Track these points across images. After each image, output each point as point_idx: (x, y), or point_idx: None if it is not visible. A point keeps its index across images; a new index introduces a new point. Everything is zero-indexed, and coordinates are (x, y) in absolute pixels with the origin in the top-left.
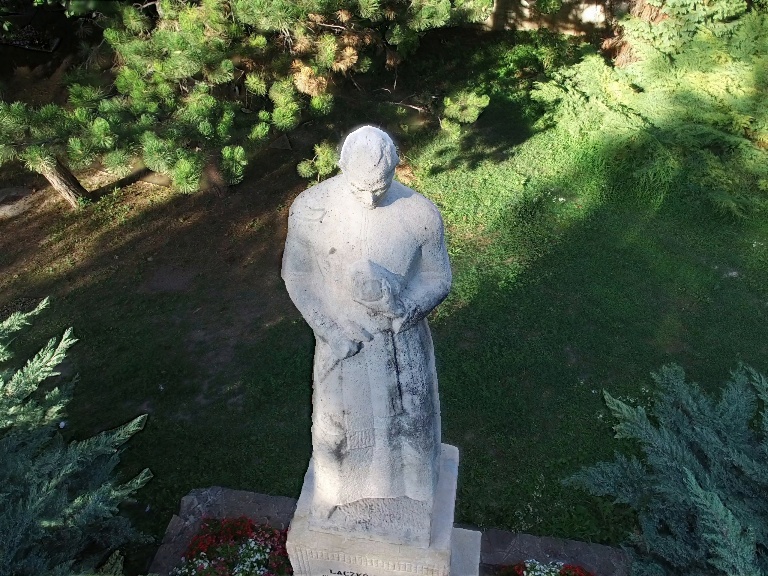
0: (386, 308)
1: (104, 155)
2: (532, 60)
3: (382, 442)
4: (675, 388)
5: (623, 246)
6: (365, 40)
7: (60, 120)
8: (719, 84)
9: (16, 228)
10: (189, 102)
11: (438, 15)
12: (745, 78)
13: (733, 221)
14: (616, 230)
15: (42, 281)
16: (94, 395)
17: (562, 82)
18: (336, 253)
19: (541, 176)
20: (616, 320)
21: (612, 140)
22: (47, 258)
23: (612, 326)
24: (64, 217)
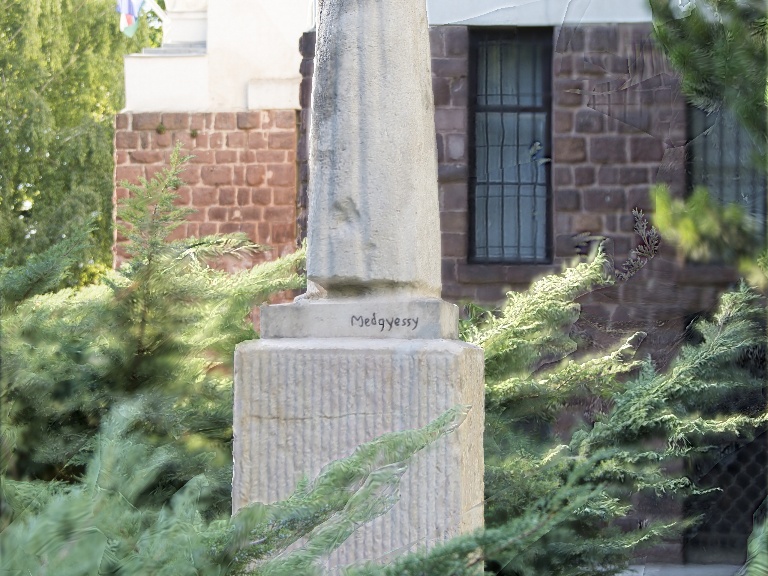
0: None
1: None
2: None
3: None
4: None
5: None
6: None
7: None
8: None
9: None
10: None
11: None
12: None
13: None
14: None
15: None
16: None
17: None
18: None
19: None
20: None
21: None
22: None
23: None
24: None
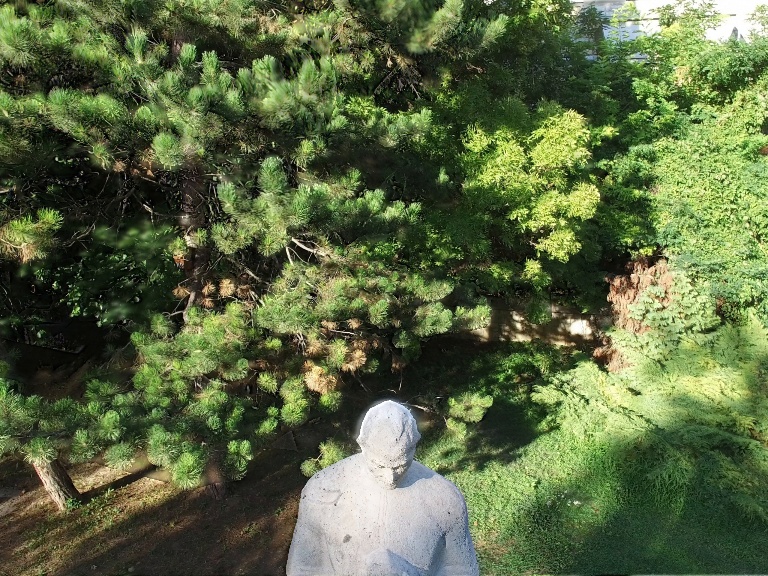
0: None
1: (108, 448)
2: (528, 367)
3: None
4: None
5: (651, 556)
6: (373, 344)
7: (71, 413)
8: (713, 387)
9: None
10: (201, 398)
11: (441, 323)
12: (737, 382)
13: (764, 527)
14: (640, 537)
15: None
16: None
17: (560, 386)
18: (350, 541)
19: (551, 478)
20: None
21: (618, 441)
22: (17, 568)
23: None
24: (48, 521)
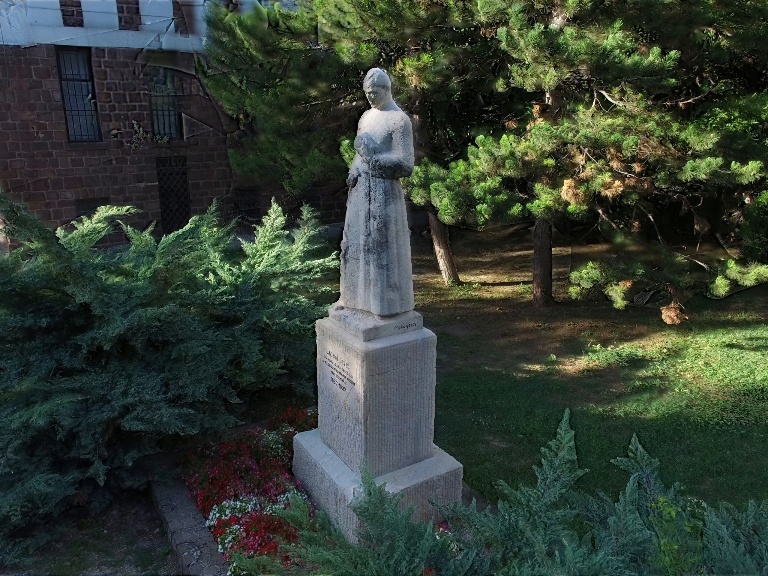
0: None
1: None
2: None
3: None
4: (760, 516)
5: None
6: (644, 185)
7: None
8: None
9: None
10: None
11: (700, 169)
12: None
13: None
14: None
15: None
16: None
17: None
18: None
19: None
20: None
21: None
22: None
23: None
24: (436, 287)
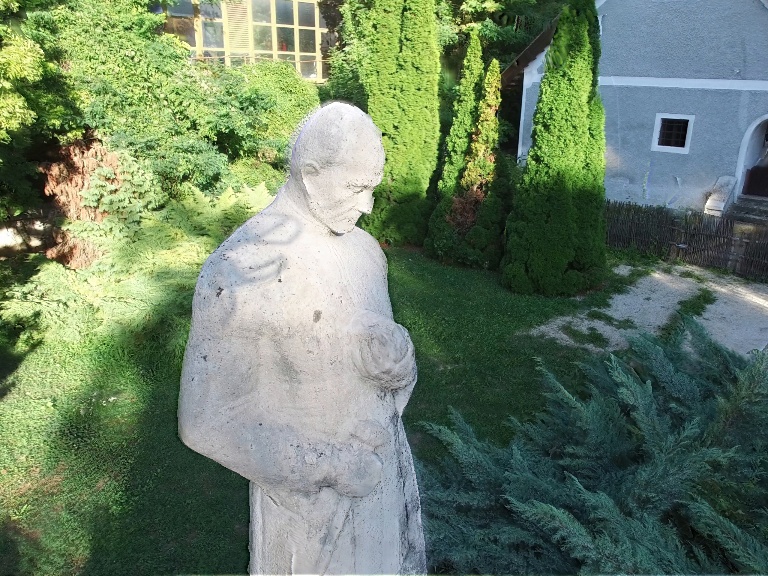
0: (410, 366)
1: None
2: None
3: None
4: None
5: None
6: None
7: None
8: (190, 254)
9: None
10: None
11: None
12: (209, 243)
13: None
14: None
15: None
16: None
17: (24, 299)
18: (321, 317)
19: (65, 391)
20: None
21: (122, 329)
22: None
23: None
24: None
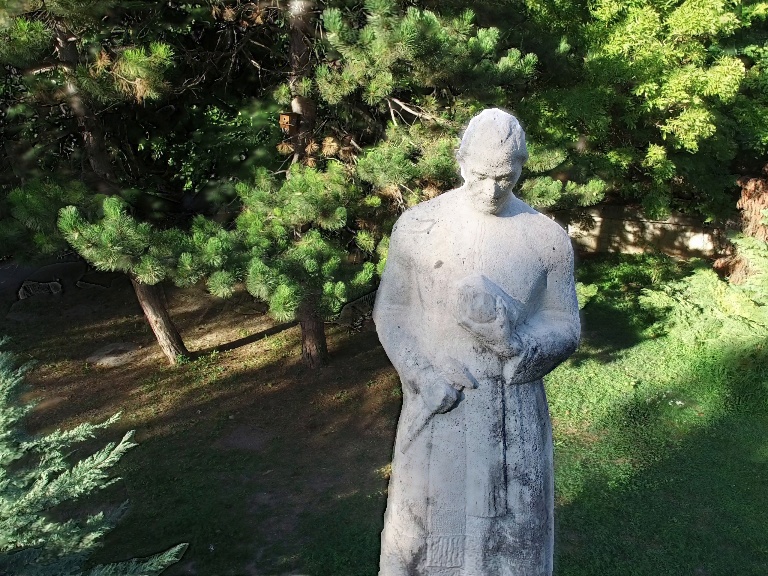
0: (499, 335)
1: (210, 275)
2: (638, 277)
3: (474, 561)
4: None
5: (759, 460)
6: None
7: None
8: None
9: (114, 377)
10: (300, 245)
11: (549, 194)
12: None
13: None
14: (748, 442)
15: (122, 426)
16: (139, 546)
17: (672, 294)
18: (443, 267)
19: (653, 380)
20: (761, 543)
21: (734, 349)
22: (134, 405)
23: (756, 549)
24: (160, 371)
